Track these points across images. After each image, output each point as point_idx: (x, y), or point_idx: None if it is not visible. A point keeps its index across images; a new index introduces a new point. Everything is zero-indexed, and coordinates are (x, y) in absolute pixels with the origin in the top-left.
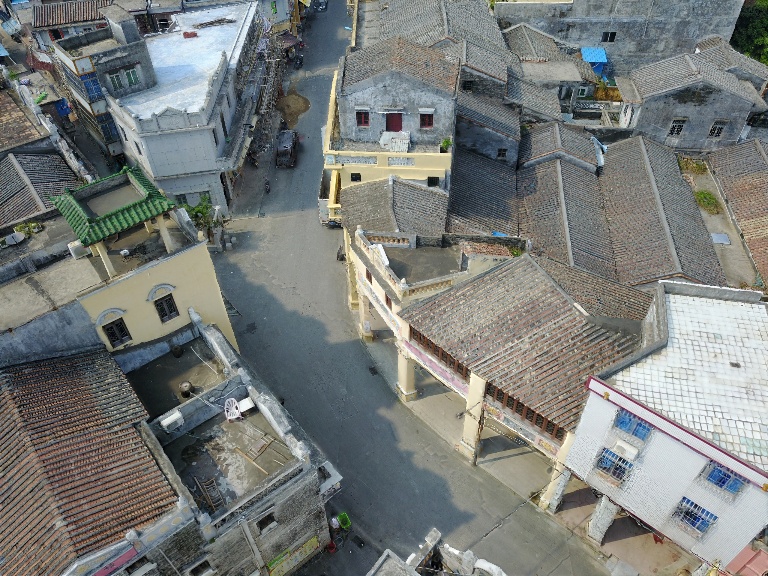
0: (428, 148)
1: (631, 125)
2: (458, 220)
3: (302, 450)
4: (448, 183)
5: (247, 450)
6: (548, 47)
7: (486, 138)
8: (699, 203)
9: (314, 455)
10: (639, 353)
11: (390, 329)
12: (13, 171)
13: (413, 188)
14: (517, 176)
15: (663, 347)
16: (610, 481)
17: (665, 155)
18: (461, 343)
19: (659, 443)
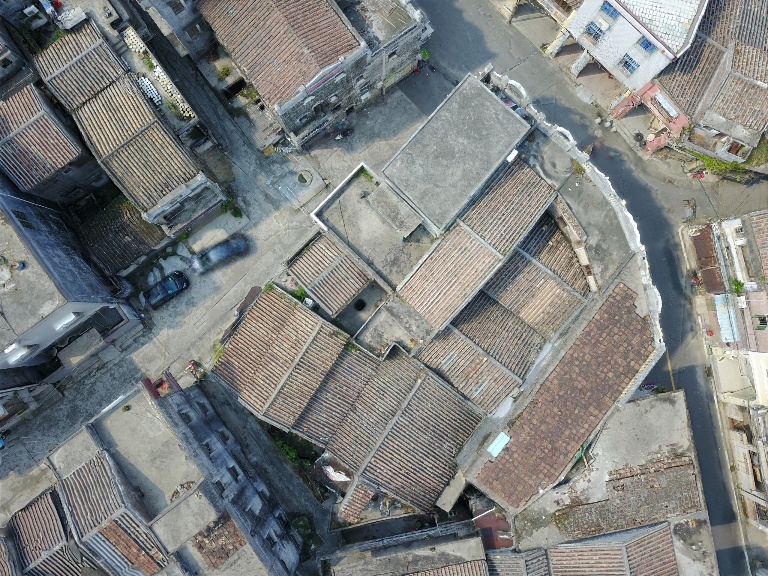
0: None
1: None
2: None
3: (419, 15)
4: None
5: (382, 12)
6: None
7: None
8: None
9: None
10: None
11: None
12: None
13: None
14: None
15: None
16: (590, 41)
17: None
18: None
19: (621, 22)
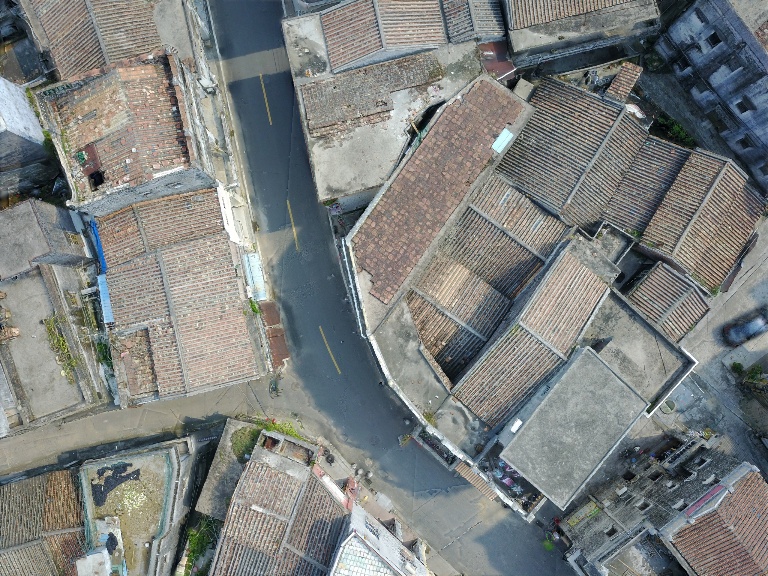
0: None
1: None
2: None
3: (604, 572)
4: None
5: (633, 575)
6: None
7: None
8: None
9: (592, 571)
10: None
11: None
12: None
13: None
14: None
15: None
16: (406, 553)
17: None
18: None
19: None
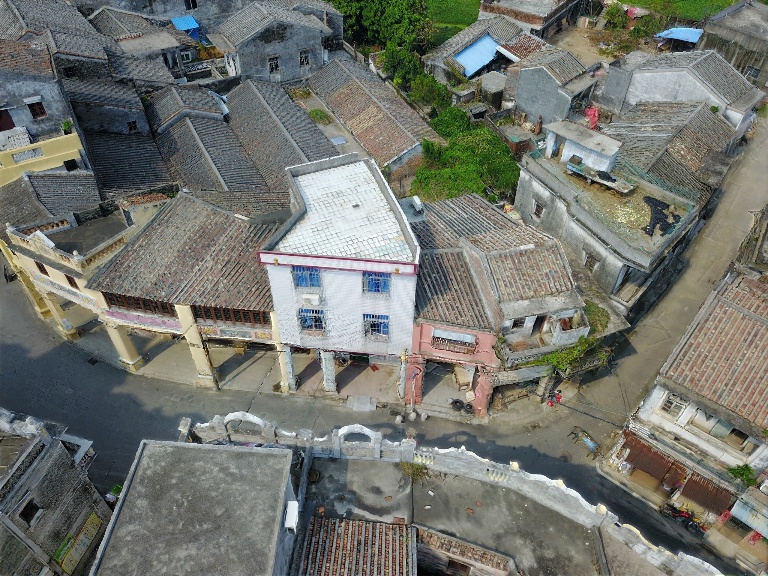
0: (52, 136)
1: (237, 72)
2: (112, 193)
3: (34, 424)
4: (87, 162)
5: None
6: (138, 24)
7: (110, 116)
8: (314, 120)
9: (51, 430)
10: (288, 222)
11: (93, 319)
12: None
13: (53, 177)
14: (156, 143)
15: (304, 213)
16: (316, 334)
17: (274, 90)
18: (155, 285)
19: (329, 281)
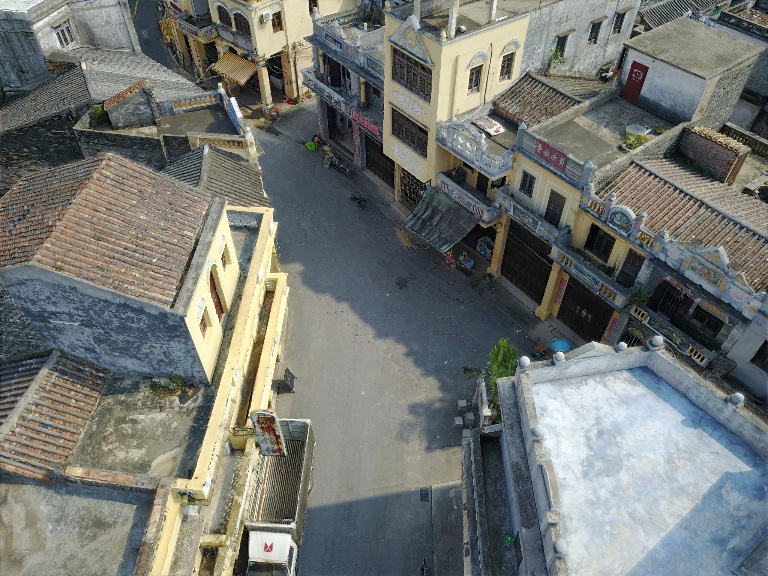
0: None
1: None
2: None
3: None
4: None
5: None
6: None
7: None
8: None
9: (312, 39)
10: None
11: None
12: (764, 231)
13: None
14: None
15: None
16: None
17: None
18: None
19: None
